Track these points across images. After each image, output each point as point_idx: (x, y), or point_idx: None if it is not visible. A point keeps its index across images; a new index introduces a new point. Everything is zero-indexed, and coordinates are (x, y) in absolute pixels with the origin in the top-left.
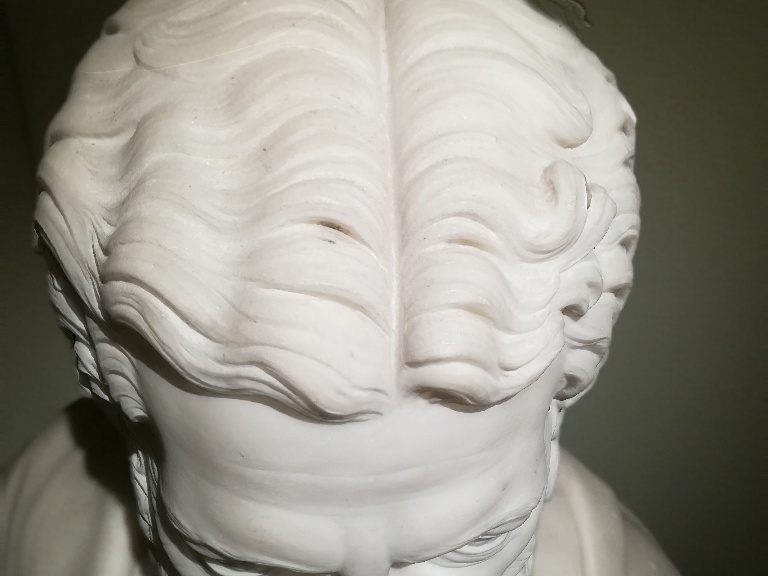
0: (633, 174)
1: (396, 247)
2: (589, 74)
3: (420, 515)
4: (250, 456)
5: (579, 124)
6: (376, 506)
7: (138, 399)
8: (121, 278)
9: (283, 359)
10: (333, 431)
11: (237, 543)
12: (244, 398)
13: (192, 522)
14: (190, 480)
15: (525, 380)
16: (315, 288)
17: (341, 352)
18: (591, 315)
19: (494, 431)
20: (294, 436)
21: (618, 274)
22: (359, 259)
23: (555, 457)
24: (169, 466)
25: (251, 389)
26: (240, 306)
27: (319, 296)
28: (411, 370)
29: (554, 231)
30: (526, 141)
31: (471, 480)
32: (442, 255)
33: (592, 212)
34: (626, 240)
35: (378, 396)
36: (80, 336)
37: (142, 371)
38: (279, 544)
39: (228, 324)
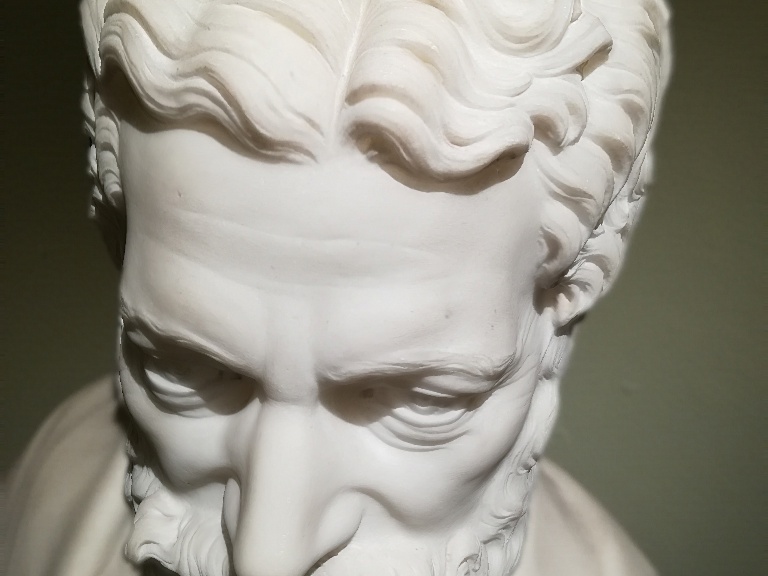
0: (652, 53)
1: (365, 4)
2: None
3: (347, 310)
4: (186, 194)
5: None
6: (303, 286)
7: (117, 171)
8: (114, 8)
9: (224, 62)
10: (266, 171)
11: (164, 311)
12: (191, 127)
13: (132, 296)
14: (138, 244)
15: (471, 157)
16: (270, 4)
17: (281, 67)
18: (574, 156)
19: (438, 227)
20: (229, 173)
21: (612, 126)
22: None
23: (550, 400)
24: (127, 239)
25: (194, 105)
26: (201, 19)
27: (273, 15)
28: (350, 108)
29: (528, 18)
30: None
31: (408, 283)
32: (402, 3)
33: (579, 26)
34: (631, 107)
35: (313, 133)
36: (93, 133)
37: (122, 130)
38: (200, 311)
39: (188, 38)
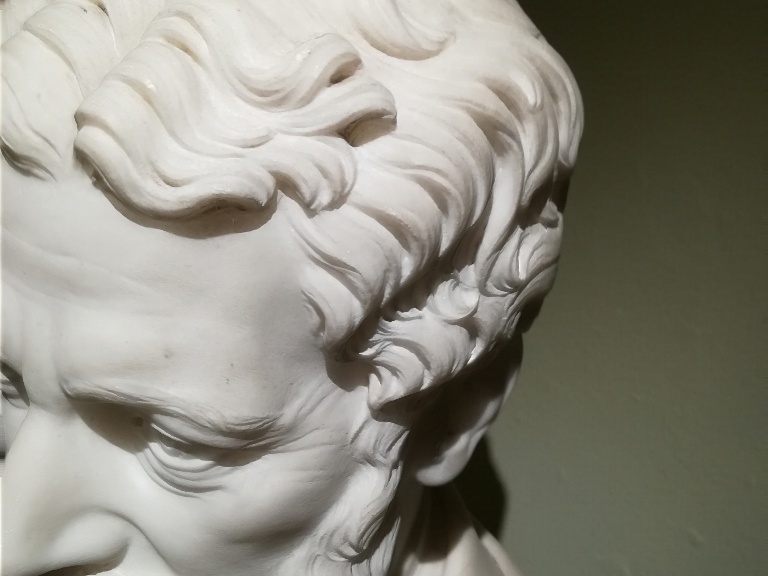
0: (483, 134)
1: None
2: (490, 34)
3: (75, 327)
4: None
5: (391, 24)
6: (46, 296)
7: None
8: None
9: None
10: (23, 183)
11: None
12: None
13: None
14: None
15: (176, 199)
16: (44, 32)
17: (31, 88)
18: (332, 222)
19: (157, 264)
20: (2, 180)
21: (386, 199)
22: (98, 32)
23: (372, 490)
24: None
25: None
26: None
27: (47, 43)
28: None
29: (271, 72)
30: (314, 8)
31: (127, 313)
32: None
33: (340, 88)
34: (431, 185)
35: (52, 152)
36: None
37: None
38: None
39: None
